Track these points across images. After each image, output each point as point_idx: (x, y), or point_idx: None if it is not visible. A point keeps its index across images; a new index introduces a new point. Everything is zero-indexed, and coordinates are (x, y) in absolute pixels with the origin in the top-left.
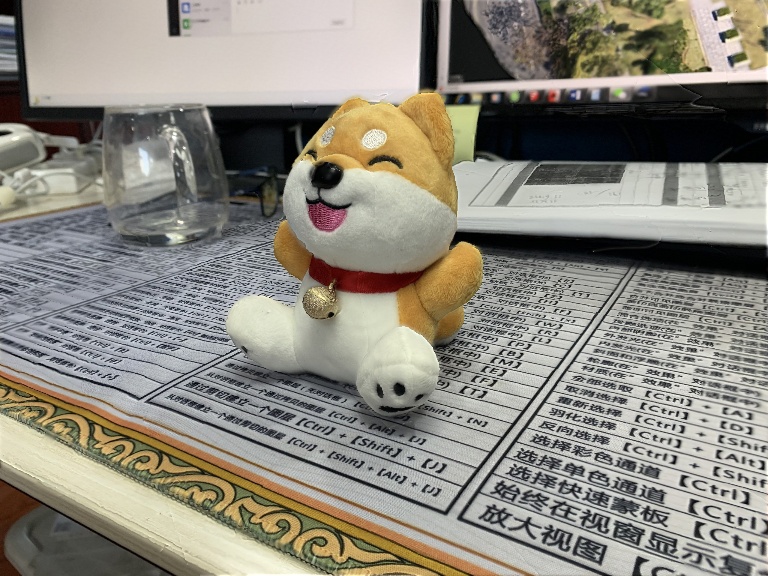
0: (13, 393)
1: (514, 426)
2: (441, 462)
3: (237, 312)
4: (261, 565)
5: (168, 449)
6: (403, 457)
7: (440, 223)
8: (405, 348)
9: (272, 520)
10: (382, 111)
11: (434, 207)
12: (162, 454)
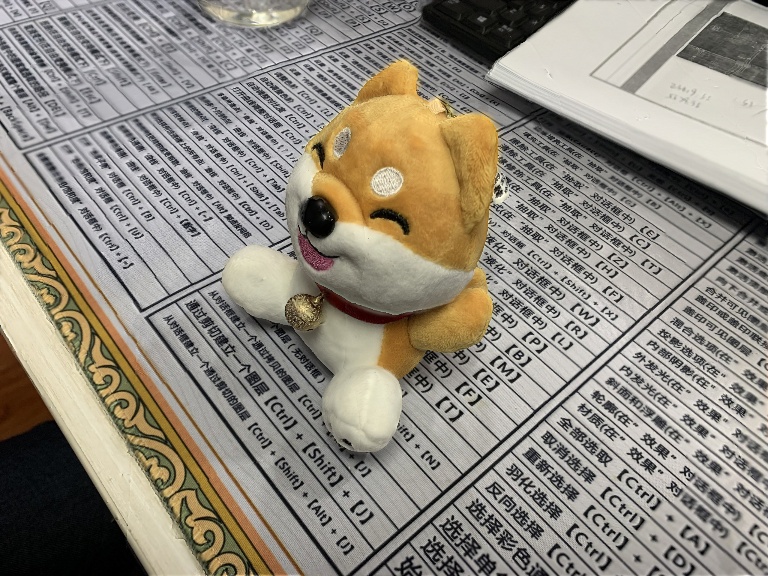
0: (39, 259)
1: (462, 479)
2: (370, 509)
3: (232, 271)
4: (181, 572)
5: (146, 398)
6: (340, 490)
7: (443, 290)
8: (361, 414)
9: (203, 527)
10: (411, 137)
11: (437, 279)
12: (140, 403)
